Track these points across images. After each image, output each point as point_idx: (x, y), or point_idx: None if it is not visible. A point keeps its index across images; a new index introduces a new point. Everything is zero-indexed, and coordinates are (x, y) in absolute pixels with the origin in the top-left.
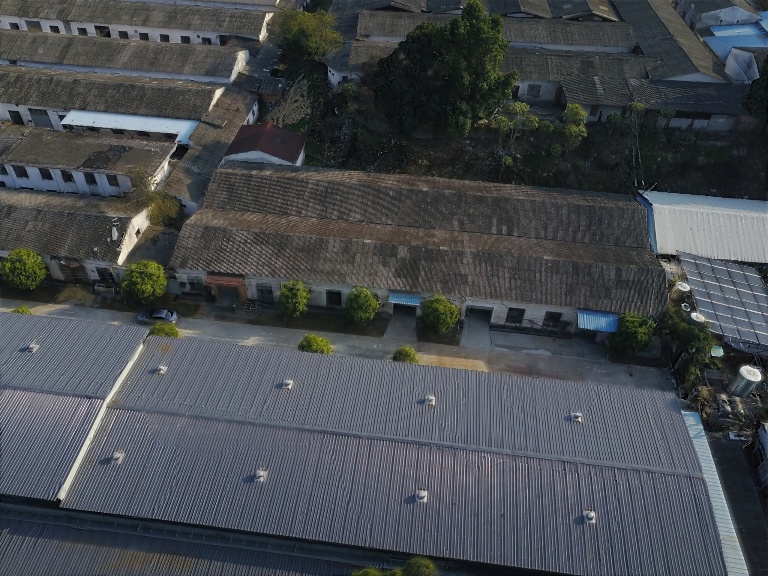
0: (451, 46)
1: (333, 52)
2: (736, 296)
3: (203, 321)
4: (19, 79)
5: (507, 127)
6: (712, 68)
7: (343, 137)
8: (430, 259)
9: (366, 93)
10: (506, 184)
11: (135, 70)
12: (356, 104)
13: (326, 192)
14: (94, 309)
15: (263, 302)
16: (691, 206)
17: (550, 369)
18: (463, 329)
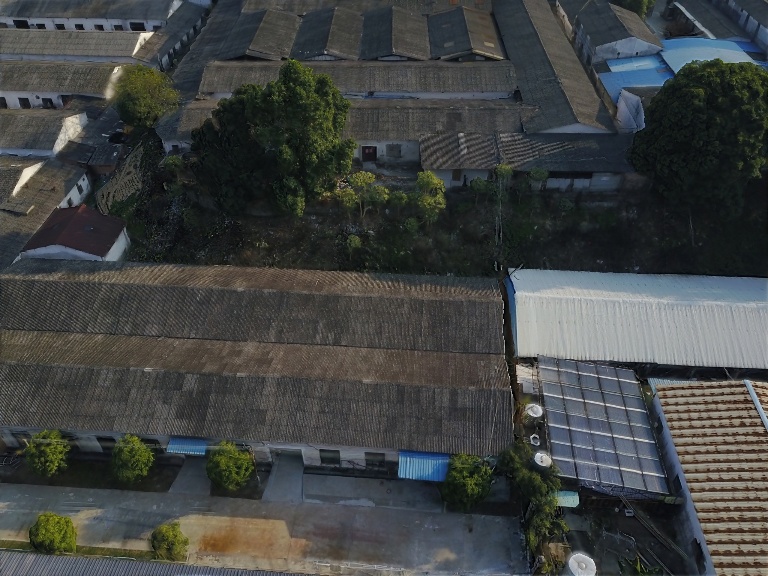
0: (266, 115)
1: (167, 115)
2: (603, 416)
3: None
4: None
5: (351, 201)
6: (596, 115)
7: (172, 217)
8: (222, 391)
9: None
10: (347, 272)
11: None
12: (185, 178)
13: (120, 299)
14: None
15: None
16: (562, 291)
17: (369, 528)
18: (270, 474)
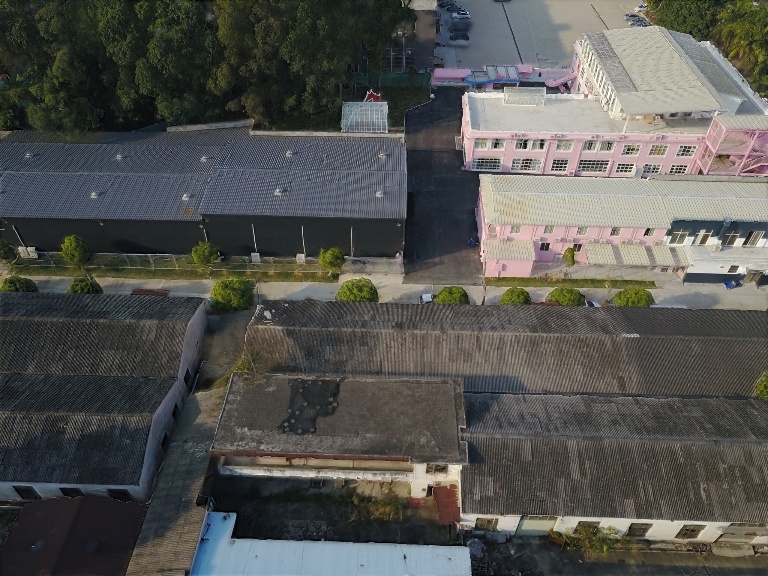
0: None
1: None
2: None
3: None
4: None
5: None
6: None
7: None
8: None
9: None
10: None
11: None
12: None
13: None
14: None
15: None
16: None
17: None
18: None
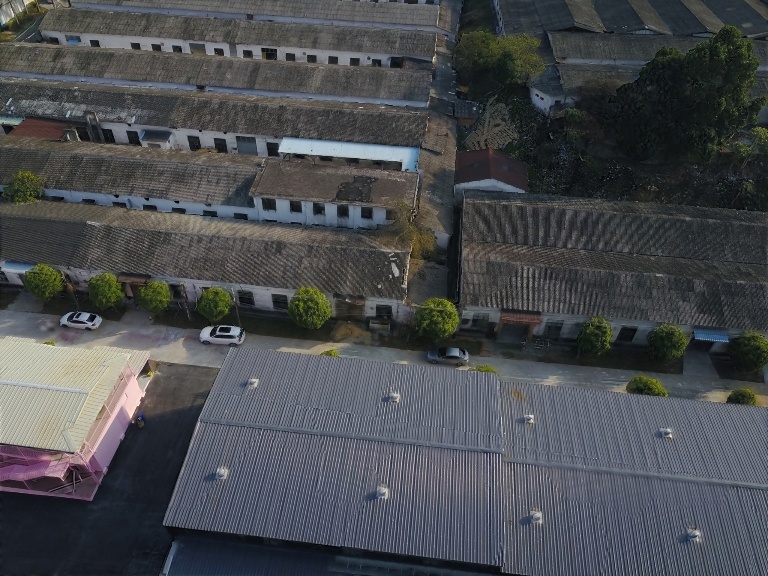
0: (707, 72)
1: (536, 75)
2: None
3: (493, 359)
4: (223, 106)
5: (746, 152)
6: None
7: (562, 163)
8: (730, 293)
9: (586, 118)
10: (755, 211)
11: (329, 95)
12: (575, 129)
13: (586, 222)
14: (376, 347)
15: (547, 338)
16: None
17: None
18: None
